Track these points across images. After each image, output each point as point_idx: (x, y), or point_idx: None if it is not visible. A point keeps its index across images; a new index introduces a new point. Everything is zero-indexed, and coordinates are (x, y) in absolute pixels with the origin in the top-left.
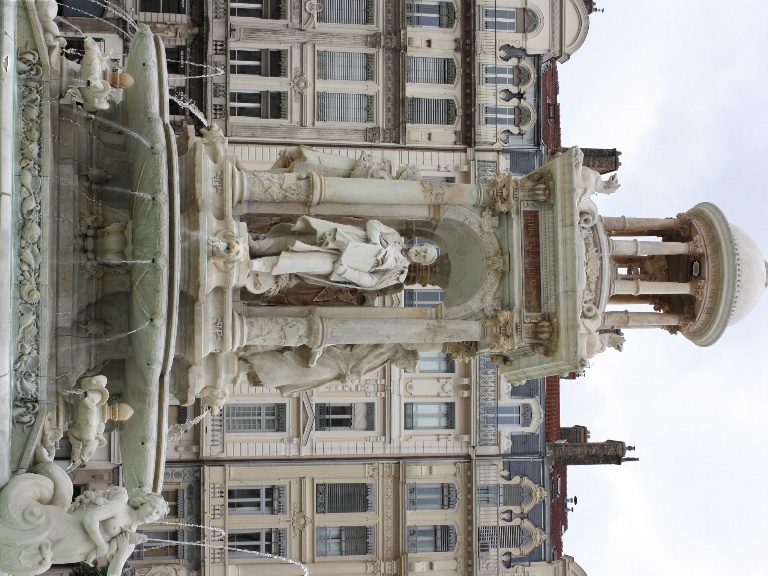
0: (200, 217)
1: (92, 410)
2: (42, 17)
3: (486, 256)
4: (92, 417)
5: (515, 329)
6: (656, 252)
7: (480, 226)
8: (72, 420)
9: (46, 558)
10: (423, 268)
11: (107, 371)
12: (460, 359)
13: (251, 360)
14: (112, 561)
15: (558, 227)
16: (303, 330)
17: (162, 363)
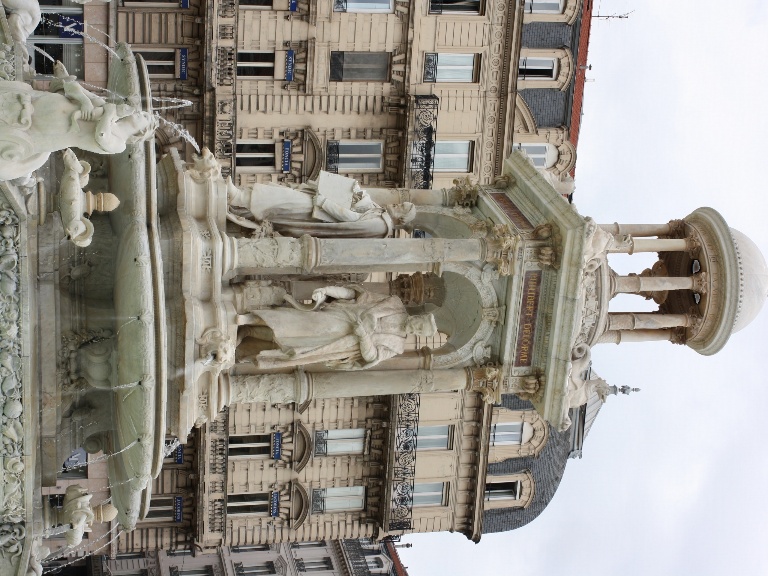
0: (171, 149)
1: (74, 171)
2: (13, 31)
3: (468, 226)
4: (74, 175)
5: (513, 235)
6: (638, 229)
7: (454, 214)
8: (60, 333)
9: (26, 106)
10: (414, 275)
11: (95, 304)
12: (492, 398)
13: (251, 310)
14: (99, 121)
15: (524, 181)
16: (294, 239)
17: (145, 173)
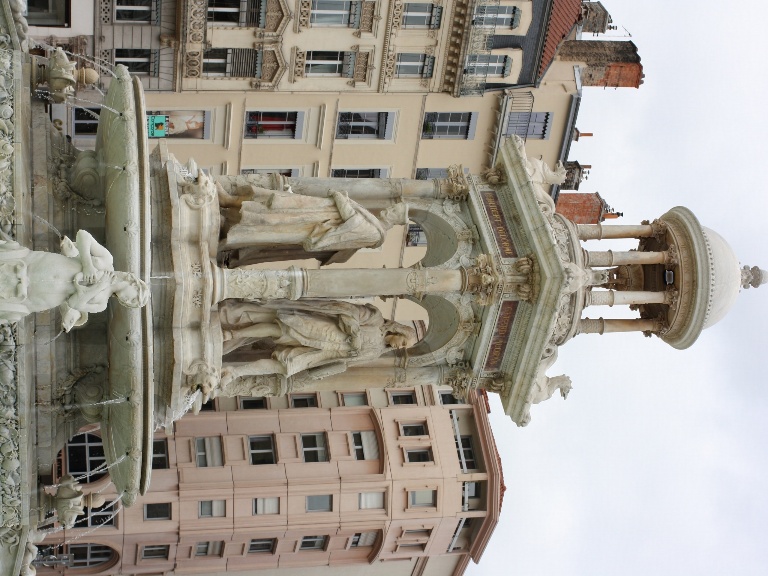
0: None
1: None
2: None
3: None
4: None
5: None
6: None
7: None
8: (50, 148)
9: None
10: None
11: None
12: None
13: None
14: None
15: None
16: None
17: None
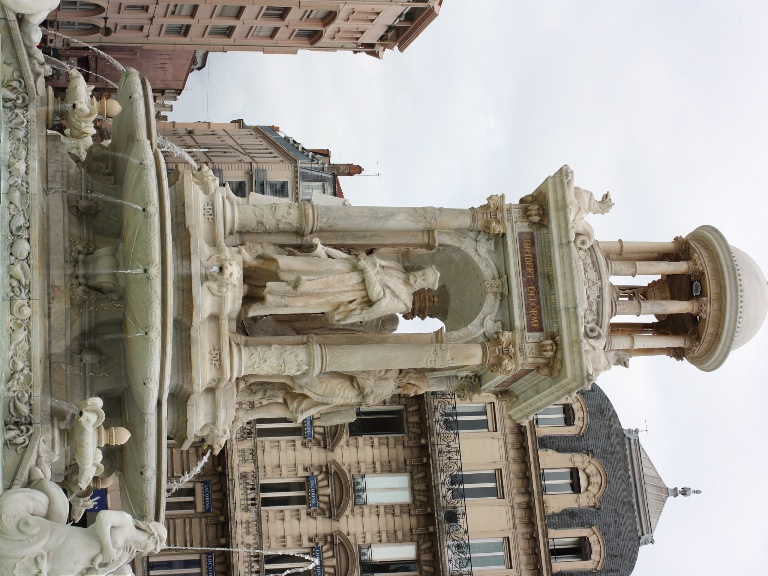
0: None
1: None
2: None
3: None
4: None
5: None
6: (627, 254)
7: None
8: (68, 232)
9: None
10: None
11: None
12: (511, 364)
13: None
14: None
15: None
16: None
17: (145, 114)
